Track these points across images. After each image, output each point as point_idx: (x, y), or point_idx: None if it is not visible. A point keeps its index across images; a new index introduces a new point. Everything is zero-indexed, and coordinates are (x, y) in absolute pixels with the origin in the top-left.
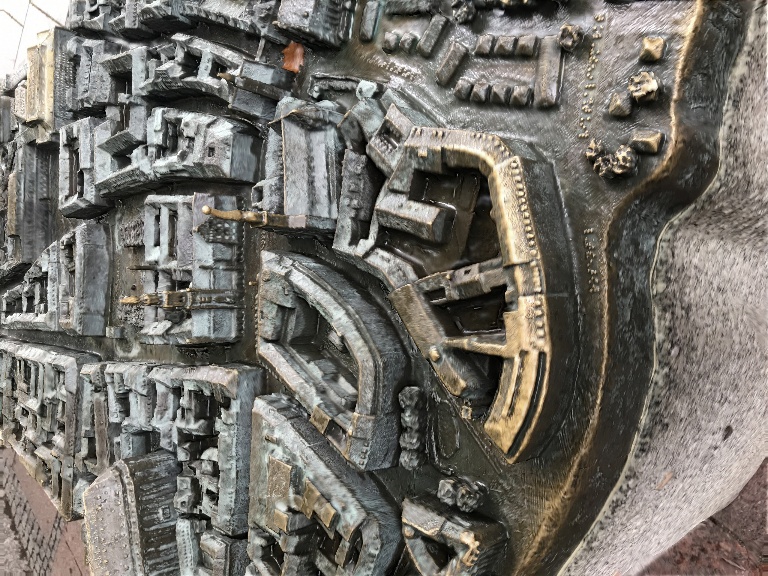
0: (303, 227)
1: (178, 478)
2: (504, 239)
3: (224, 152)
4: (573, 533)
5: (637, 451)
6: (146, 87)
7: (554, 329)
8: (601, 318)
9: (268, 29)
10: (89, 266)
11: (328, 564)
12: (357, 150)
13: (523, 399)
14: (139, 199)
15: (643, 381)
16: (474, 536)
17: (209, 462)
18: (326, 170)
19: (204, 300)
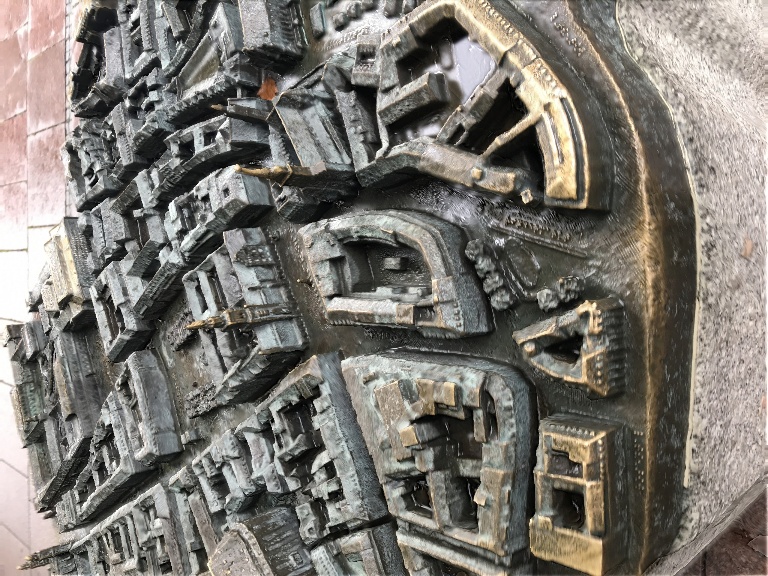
0: (324, 170)
1: (296, 508)
2: (488, 42)
3: (237, 185)
4: (681, 282)
5: (697, 188)
6: (155, 195)
7: (563, 80)
8: (598, 66)
9: (240, 76)
10: (148, 388)
11: (472, 463)
12: (345, 92)
13: (566, 141)
14: (176, 305)
15: (666, 121)
16: (588, 301)
17: (321, 470)
18: (327, 132)
19: (262, 313)
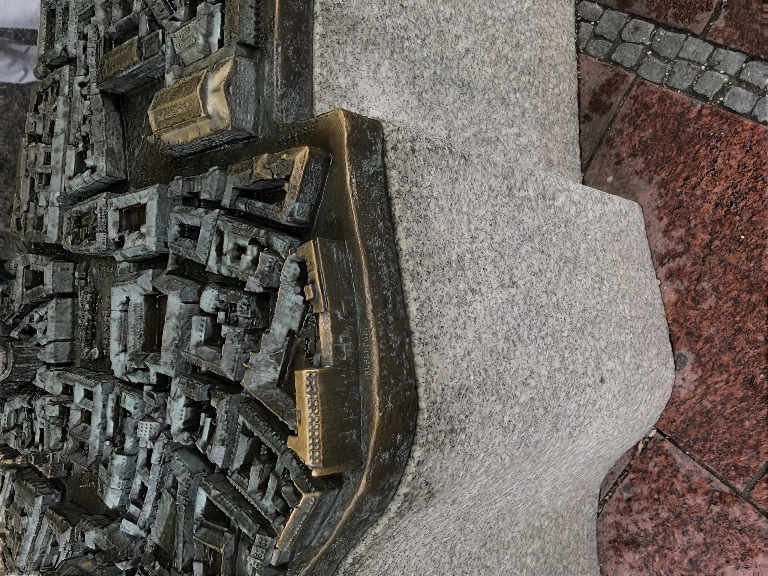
0: None
1: None
2: None
3: None
4: None
5: None
6: None
7: None
8: None
9: None
10: None
11: None
12: None
13: None
14: None
15: None
16: None
17: (35, 429)
18: None
19: None
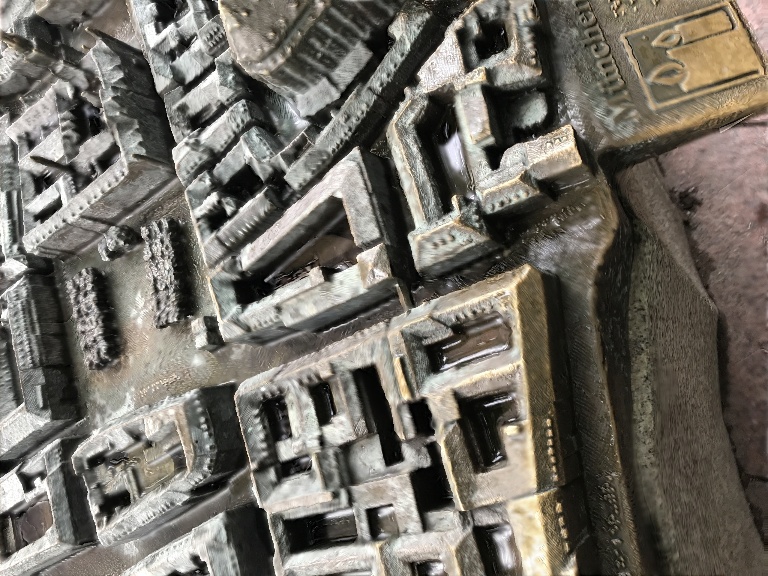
0: None
1: None
2: None
3: None
4: None
5: None
6: None
7: None
8: None
9: None
10: None
11: None
12: None
13: None
14: (76, 363)
15: None
16: None
17: None
18: None
19: None
